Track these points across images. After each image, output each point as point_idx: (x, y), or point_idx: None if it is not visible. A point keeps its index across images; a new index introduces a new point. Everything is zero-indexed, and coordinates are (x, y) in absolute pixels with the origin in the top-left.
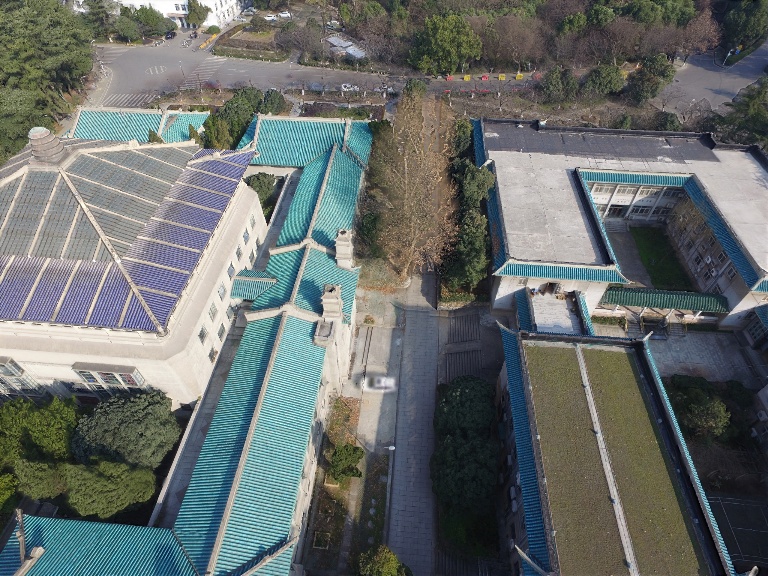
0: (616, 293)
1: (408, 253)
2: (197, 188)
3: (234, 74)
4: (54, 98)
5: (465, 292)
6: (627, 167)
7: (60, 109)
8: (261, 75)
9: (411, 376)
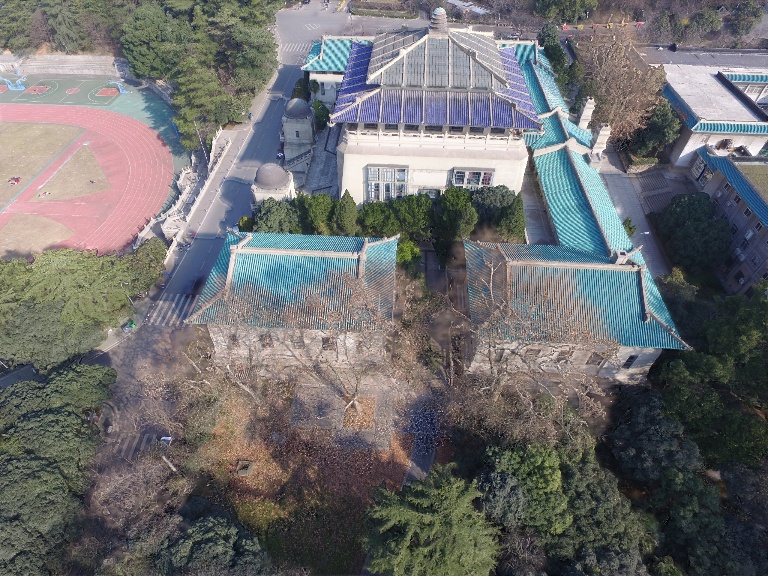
0: (767, 150)
1: None
2: None
3: None
4: None
5: (651, 157)
6: None
7: None
8: None
9: (624, 210)
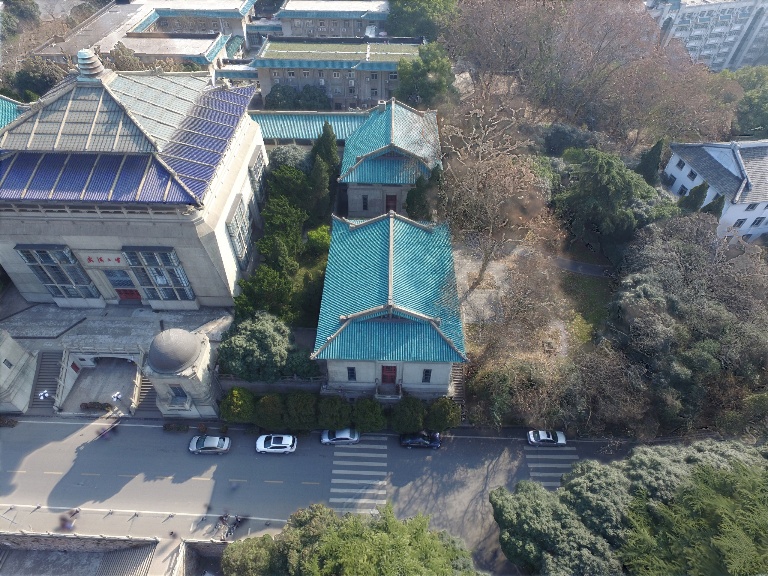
0: None
1: None
2: None
3: None
4: None
5: None
6: (132, 24)
7: None
8: None
9: None
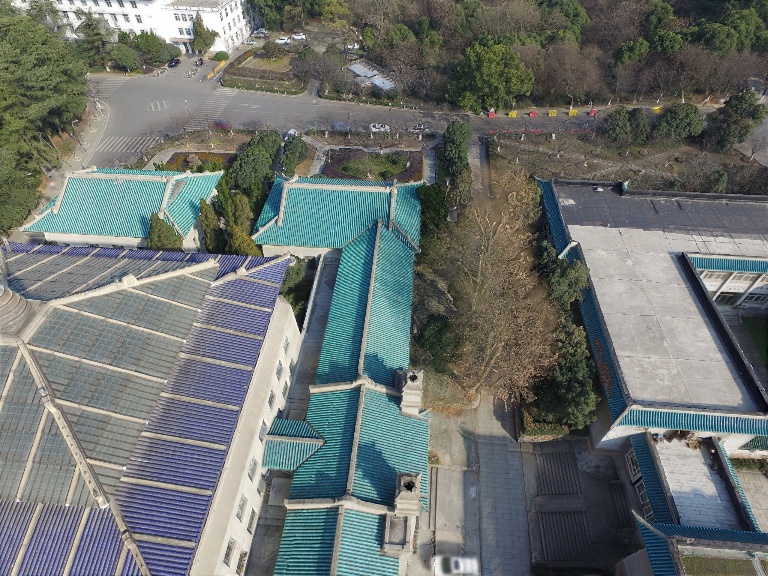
0: None
1: (480, 370)
2: (217, 330)
3: (246, 110)
4: (40, 150)
5: (556, 423)
6: (744, 248)
7: (47, 162)
8: (277, 111)
9: (495, 548)
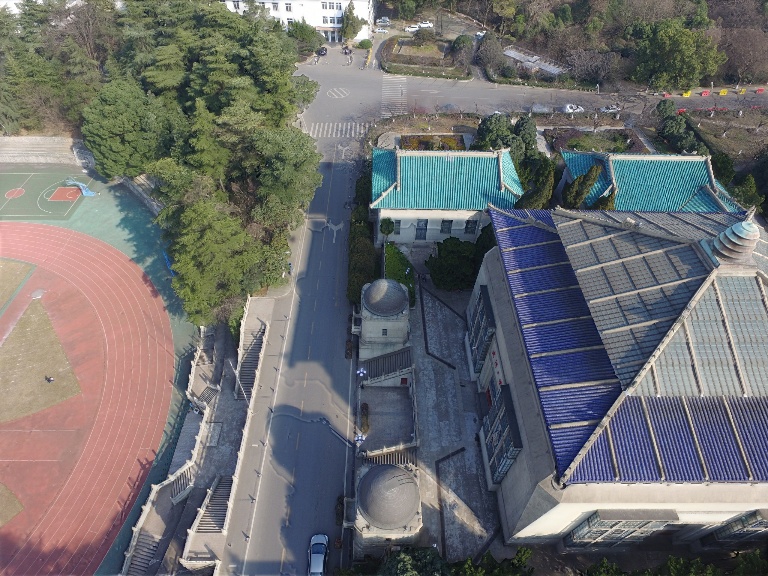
0: None
1: None
2: None
3: (430, 95)
4: None
5: None
6: None
7: None
8: (461, 96)
9: None
